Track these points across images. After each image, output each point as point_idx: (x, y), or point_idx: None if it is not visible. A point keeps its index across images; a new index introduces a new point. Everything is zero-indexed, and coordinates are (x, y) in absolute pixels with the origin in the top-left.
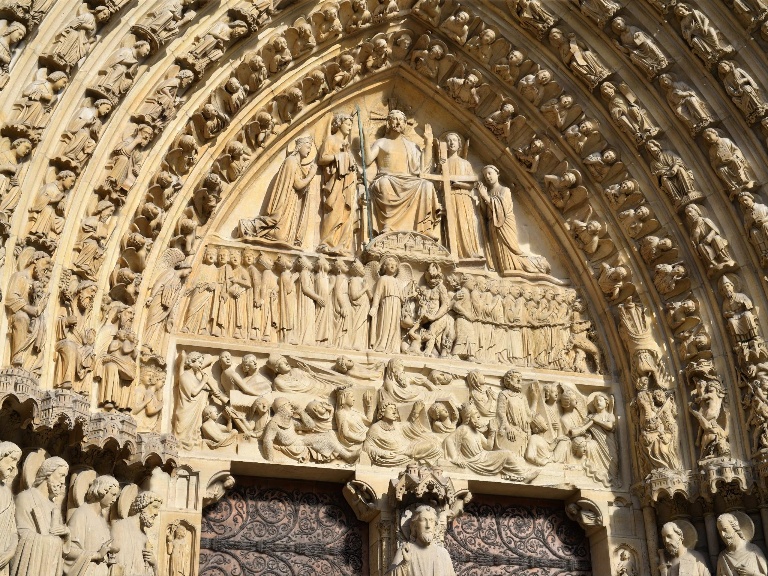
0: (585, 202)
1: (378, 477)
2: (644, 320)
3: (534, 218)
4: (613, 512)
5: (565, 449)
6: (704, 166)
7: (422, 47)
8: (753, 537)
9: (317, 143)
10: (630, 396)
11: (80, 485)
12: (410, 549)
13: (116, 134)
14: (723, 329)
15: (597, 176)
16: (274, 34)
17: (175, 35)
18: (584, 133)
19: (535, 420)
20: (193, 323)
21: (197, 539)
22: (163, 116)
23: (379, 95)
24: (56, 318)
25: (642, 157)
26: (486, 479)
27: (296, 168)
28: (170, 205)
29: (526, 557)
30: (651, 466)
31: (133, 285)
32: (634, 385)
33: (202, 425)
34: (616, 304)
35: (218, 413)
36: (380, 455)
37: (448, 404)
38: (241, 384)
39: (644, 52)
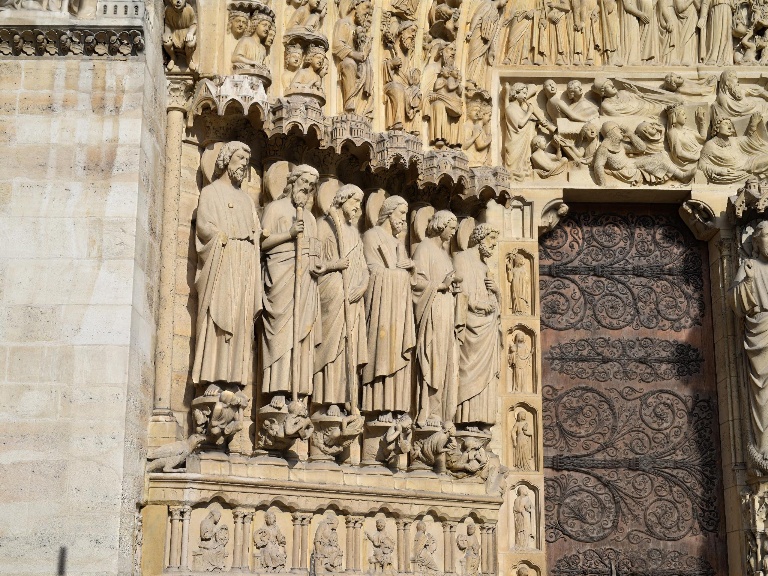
0: None
1: (715, 195)
2: None
3: None
4: None
5: None
6: None
7: None
8: None
9: None
10: None
11: (420, 221)
12: (753, 265)
13: None
14: None
15: None
16: None
17: None
18: None
19: None
20: (514, 54)
21: (536, 266)
22: None
23: None
24: (381, 61)
25: None
26: None
27: None
28: None
29: None
30: None
31: (452, 21)
32: None
33: (531, 155)
34: None
35: (546, 142)
36: (716, 172)
37: None
38: (567, 111)
39: None
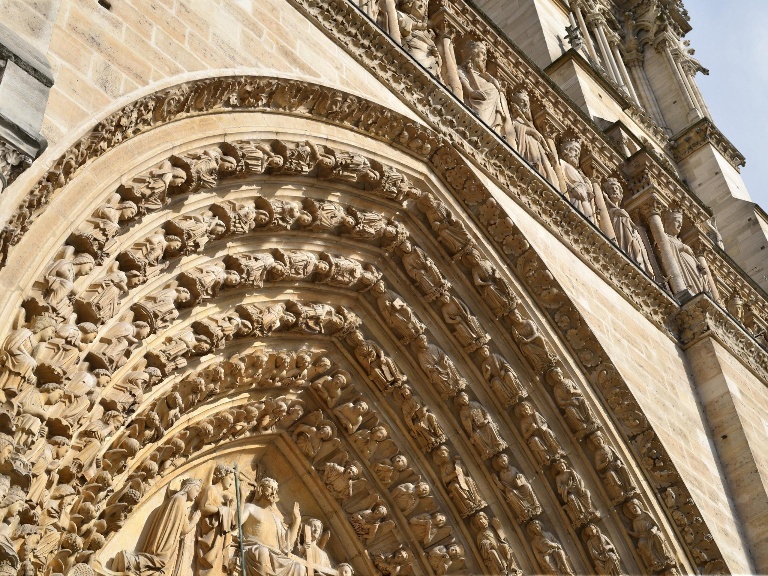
0: None
1: None
2: None
3: None
4: None
5: None
6: None
7: (310, 423)
8: None
9: None
10: None
11: None
12: None
13: None
14: None
15: None
16: (215, 361)
17: (165, 328)
18: (451, 556)
19: None
20: None
21: None
22: (130, 409)
23: (250, 457)
24: None
25: None
26: None
27: (186, 509)
28: None
29: None
30: None
31: None
32: None
33: None
34: None
35: None
36: None
37: None
38: None
39: (523, 494)
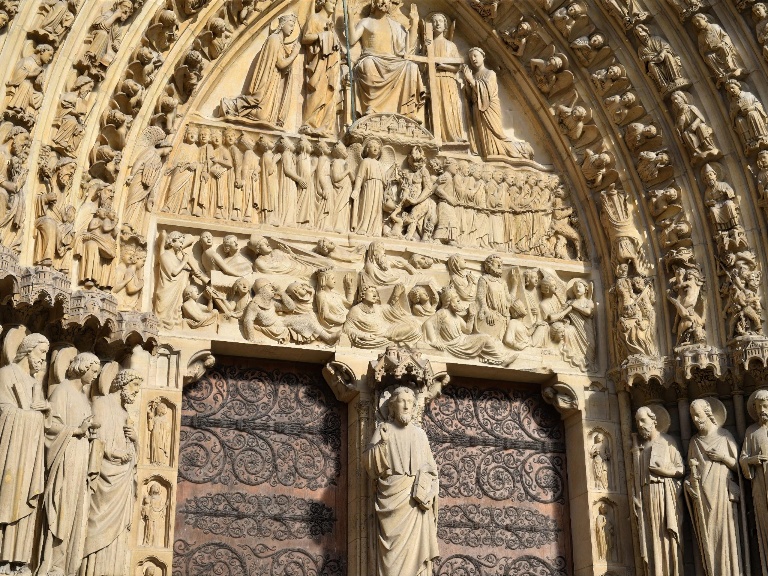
0: (571, 87)
1: (357, 358)
2: (626, 207)
3: (519, 102)
4: (589, 396)
5: (543, 334)
6: (692, 52)
7: None
8: (725, 422)
9: (300, 21)
10: (609, 283)
11: (61, 362)
12: (388, 429)
13: (95, 7)
14: (704, 218)
15: (584, 61)
16: None
17: None
18: (572, 16)
19: (514, 305)
20: (174, 203)
21: (178, 416)
22: None
23: None
24: (35, 195)
25: (630, 42)
26: (464, 362)
27: (279, 47)
28: (150, 82)
29: (502, 439)
30: (627, 352)
31: (113, 163)
32: (614, 272)
33: (183, 305)
34: (598, 191)
35: (199, 293)
36: (360, 337)
37: (428, 288)
38: (222, 264)
39: None
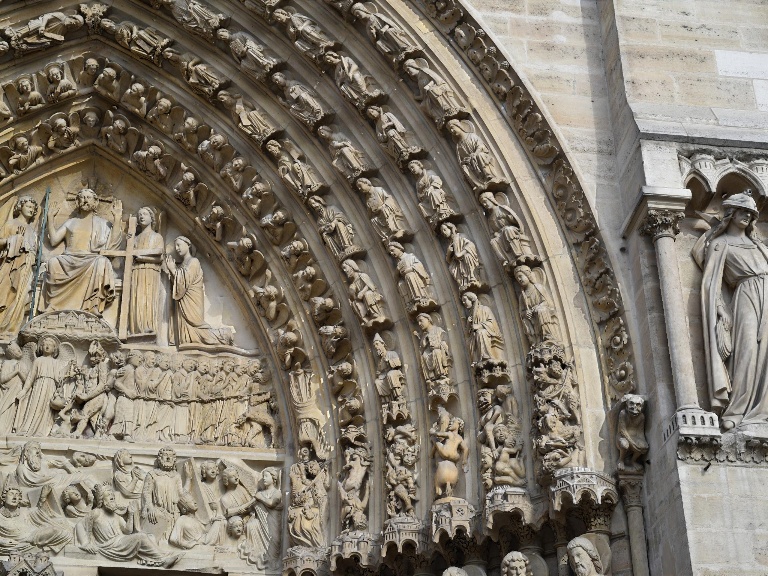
0: (267, 267)
1: None
2: (310, 387)
3: (228, 288)
4: None
5: (218, 530)
6: (365, 219)
7: (109, 123)
8: None
9: None
10: None
11: None
12: None
13: None
14: None
15: (271, 239)
16: None
17: None
18: (256, 195)
19: (181, 500)
20: None
21: None
22: None
23: (78, 175)
24: None
25: (312, 215)
26: (119, 565)
27: None
28: None
29: None
30: (294, 544)
31: None
32: None
33: None
34: None
35: None
36: None
37: (80, 486)
38: None
39: (300, 106)
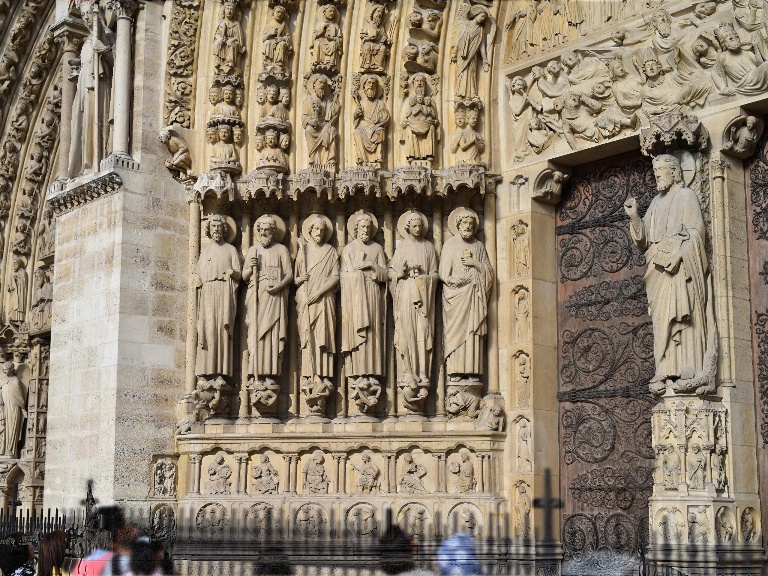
0: None
1: None
2: None
3: None
4: None
5: None
6: None
7: None
8: None
9: None
10: None
11: (401, 225)
12: (634, 204)
13: None
14: None
15: None
16: None
17: None
18: None
19: None
20: (516, 51)
21: (530, 233)
22: None
23: None
24: None
25: None
26: (758, 98)
27: None
28: None
29: None
30: None
31: (420, 57)
32: None
33: None
34: None
35: None
36: (652, 113)
37: (703, 37)
38: (545, 91)
39: None
